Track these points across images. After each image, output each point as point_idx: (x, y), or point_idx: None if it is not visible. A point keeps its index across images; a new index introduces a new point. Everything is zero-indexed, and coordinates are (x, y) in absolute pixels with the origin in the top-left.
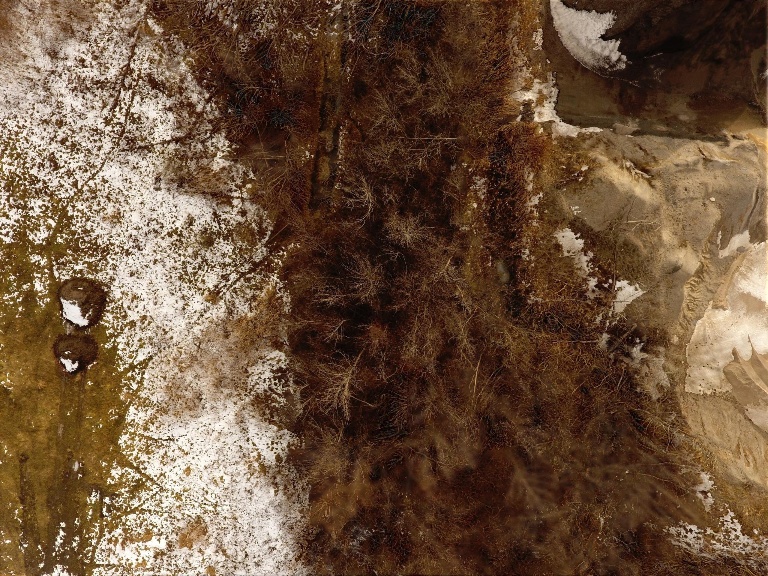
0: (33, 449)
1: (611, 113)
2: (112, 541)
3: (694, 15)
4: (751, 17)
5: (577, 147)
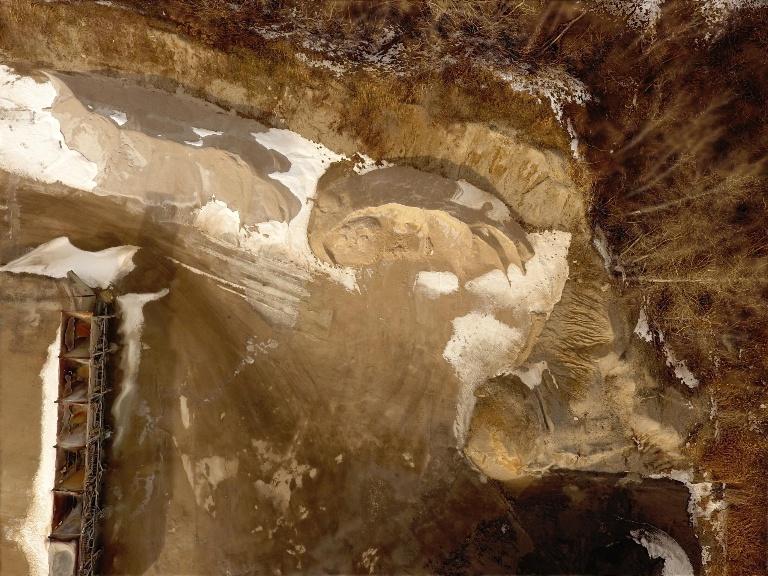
0: None
1: (639, 491)
2: None
3: None
4: None
5: None
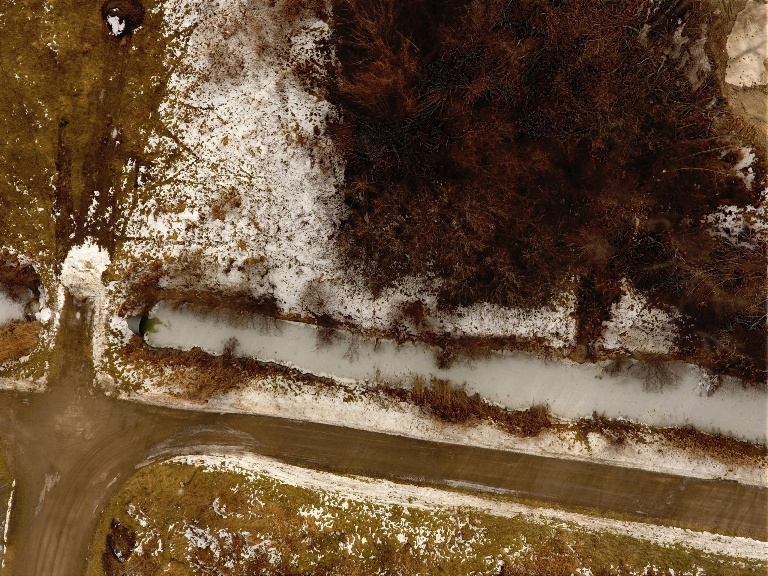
0: (73, 113)
1: None
2: (145, 212)
3: None
4: None
5: None
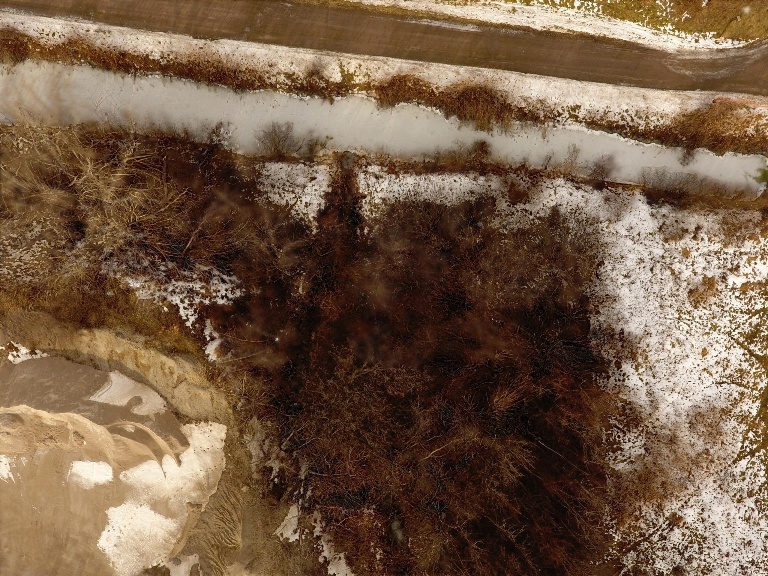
0: None
1: None
2: None
3: None
4: None
5: None
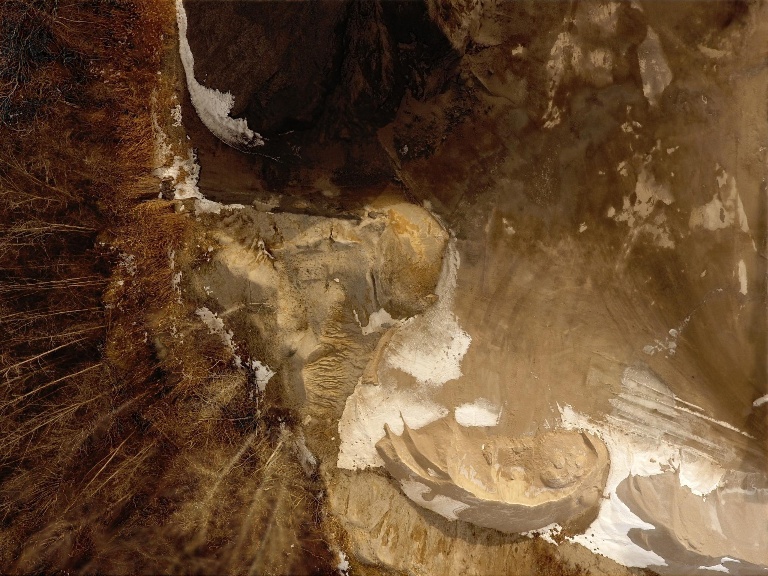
0: None
1: (255, 189)
2: None
3: (293, 99)
4: (353, 100)
5: (212, 226)
